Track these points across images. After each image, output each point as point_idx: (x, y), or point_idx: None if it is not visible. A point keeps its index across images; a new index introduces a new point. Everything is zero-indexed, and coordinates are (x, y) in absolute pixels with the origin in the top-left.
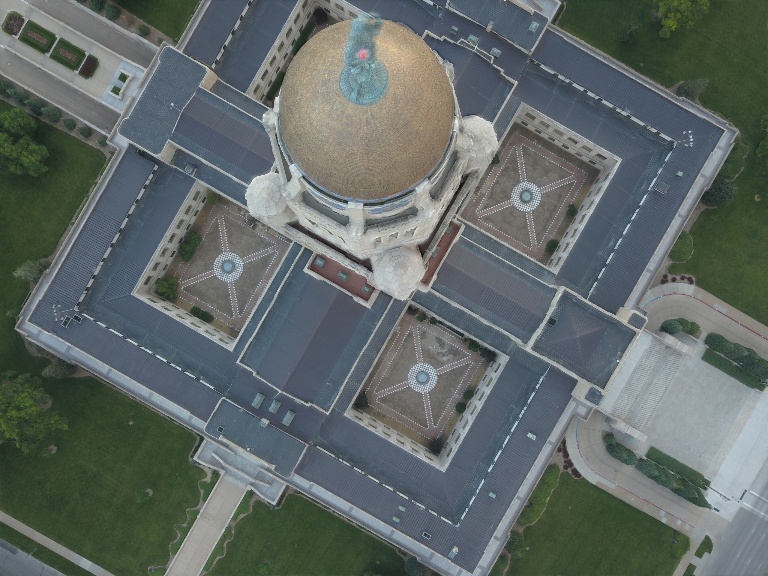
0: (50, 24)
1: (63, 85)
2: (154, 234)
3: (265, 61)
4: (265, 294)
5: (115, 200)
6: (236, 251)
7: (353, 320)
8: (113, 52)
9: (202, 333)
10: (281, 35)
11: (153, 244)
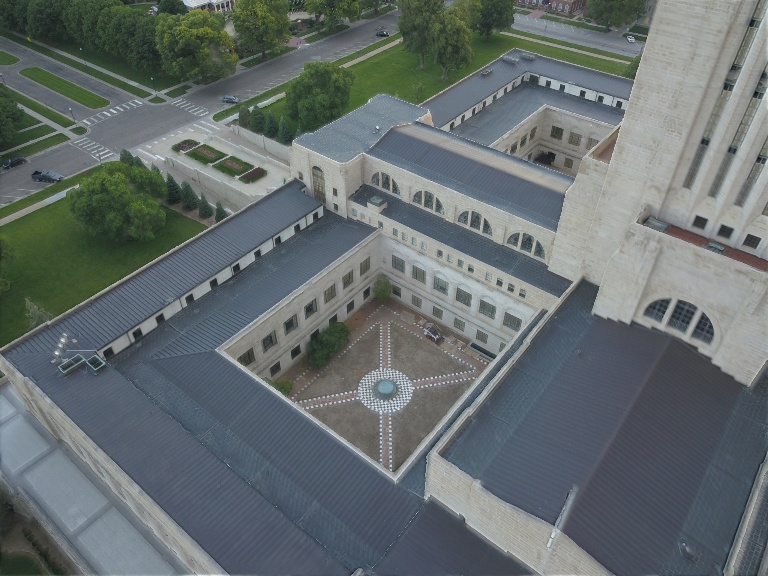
0: (226, 149)
1: (212, 196)
2: (290, 280)
3: (491, 146)
4: (479, 383)
5: (248, 228)
6: (403, 369)
7: (714, 405)
8: (288, 166)
9: (334, 434)
10: (511, 132)
11: (284, 290)
